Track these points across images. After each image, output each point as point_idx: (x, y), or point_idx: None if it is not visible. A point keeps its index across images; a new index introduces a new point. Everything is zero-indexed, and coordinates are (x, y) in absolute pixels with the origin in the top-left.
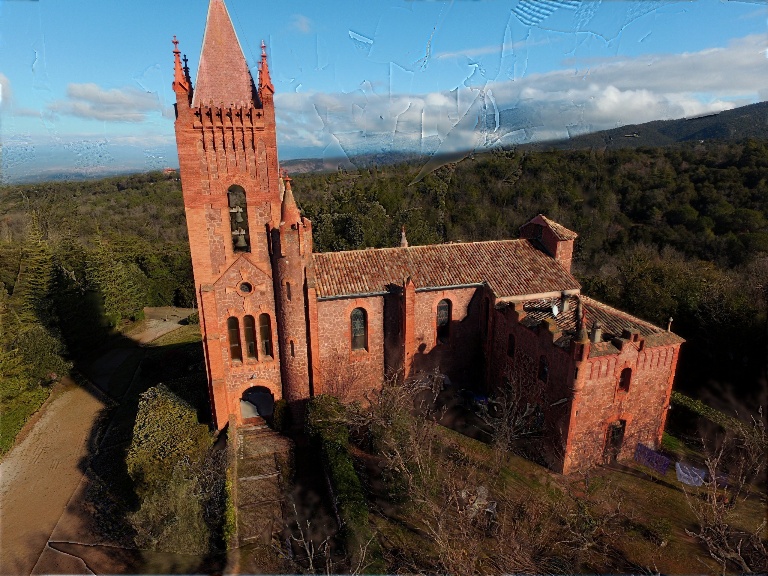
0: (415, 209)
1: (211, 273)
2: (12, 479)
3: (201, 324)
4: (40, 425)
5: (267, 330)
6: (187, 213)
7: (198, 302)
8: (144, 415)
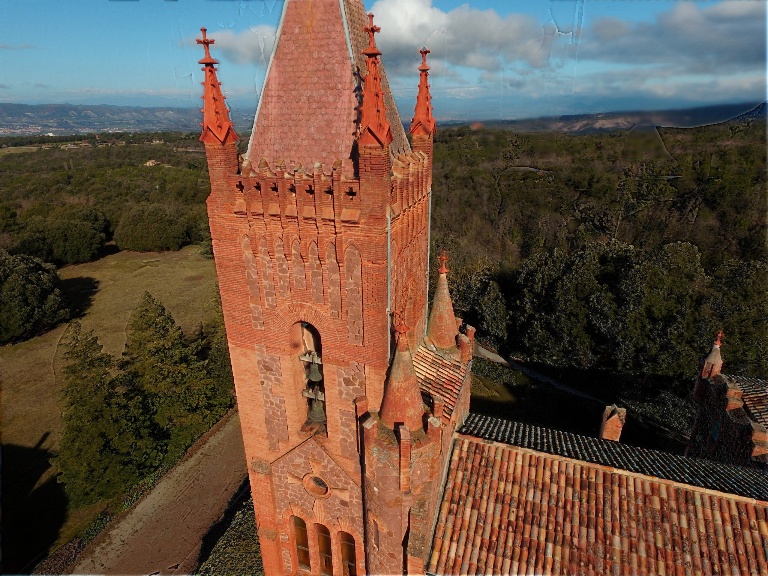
0: (763, 266)
1: (267, 447)
2: (150, 514)
3: (255, 507)
4: (212, 442)
5: (353, 550)
6: (231, 352)
7: (250, 478)
8: (223, 546)
